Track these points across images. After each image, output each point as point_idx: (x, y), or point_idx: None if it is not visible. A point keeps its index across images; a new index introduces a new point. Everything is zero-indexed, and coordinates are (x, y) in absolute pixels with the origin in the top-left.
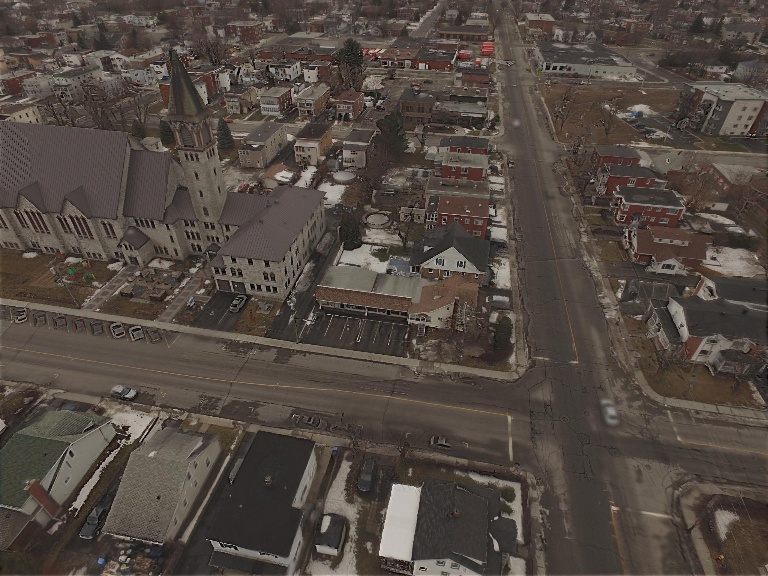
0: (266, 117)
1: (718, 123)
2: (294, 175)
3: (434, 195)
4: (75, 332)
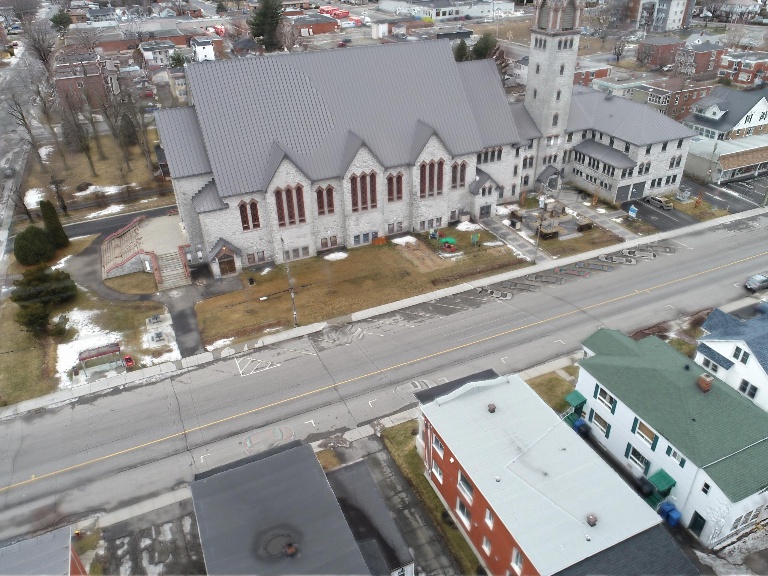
0: None
1: (664, 20)
2: None
3: (623, 90)
4: (587, 277)
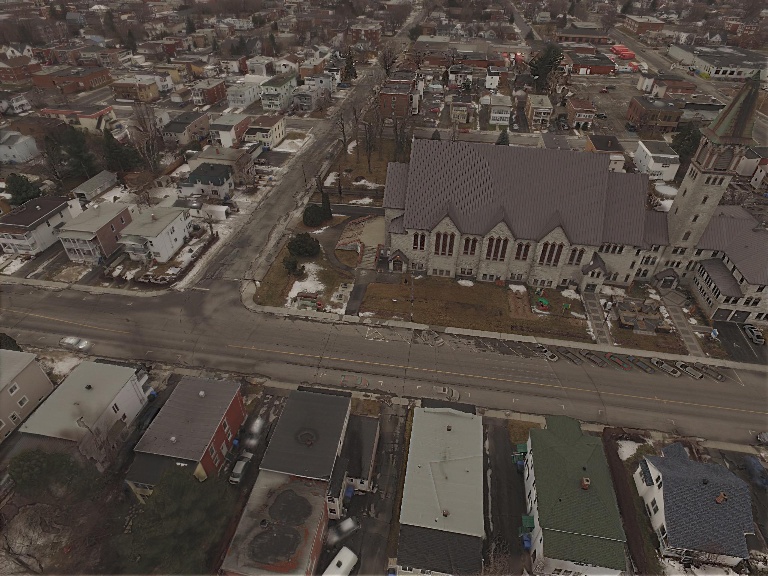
0: (497, 127)
1: None
2: None
3: None
4: (626, 370)
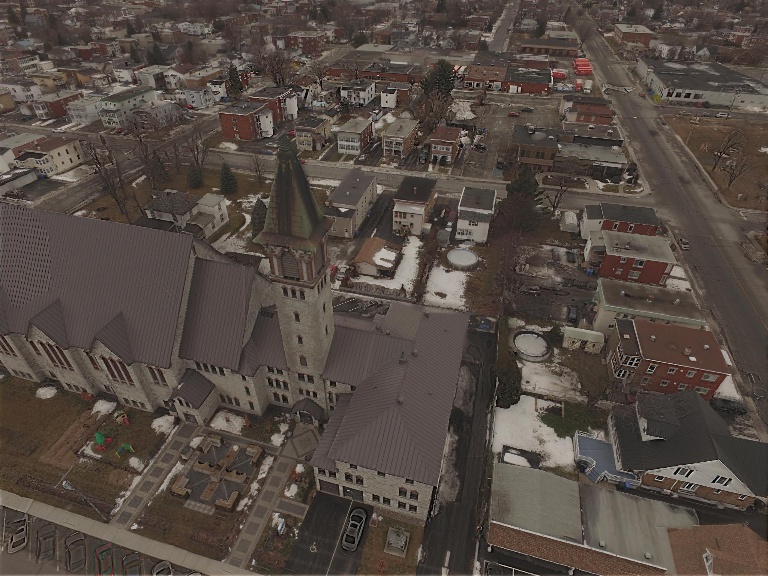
0: (344, 156)
1: None
2: (397, 256)
3: (615, 312)
4: None
